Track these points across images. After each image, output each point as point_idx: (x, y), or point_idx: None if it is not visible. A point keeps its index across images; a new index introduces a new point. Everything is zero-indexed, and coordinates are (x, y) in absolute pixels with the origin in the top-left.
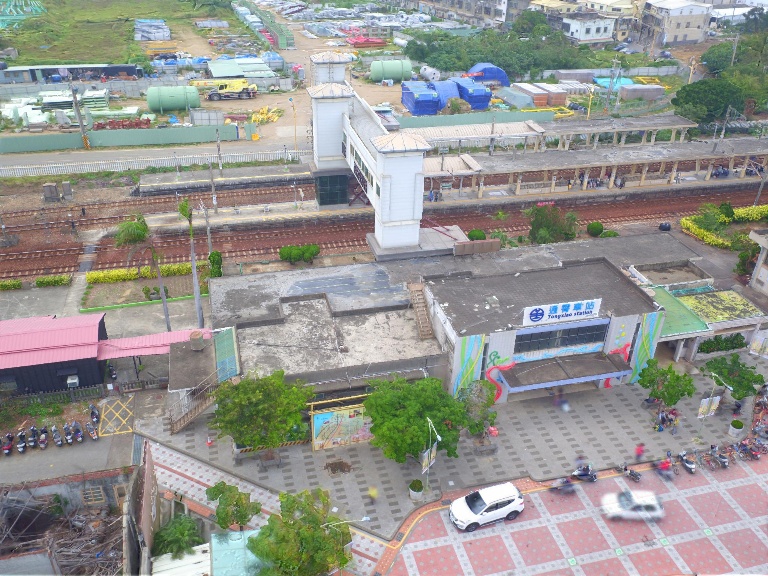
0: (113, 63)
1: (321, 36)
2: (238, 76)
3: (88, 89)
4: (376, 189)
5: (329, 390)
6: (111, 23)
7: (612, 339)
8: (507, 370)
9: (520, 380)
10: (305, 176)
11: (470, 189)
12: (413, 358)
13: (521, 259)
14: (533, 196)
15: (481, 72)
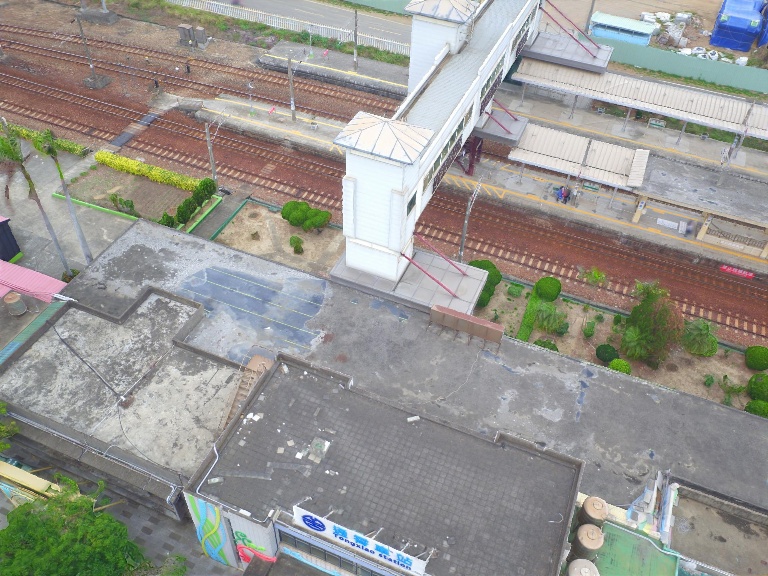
0: None
1: None
2: None
3: None
4: None
5: (56, 450)
6: None
7: None
8: (264, 561)
9: None
10: None
11: None
12: (164, 469)
13: (522, 372)
14: (722, 252)
15: None
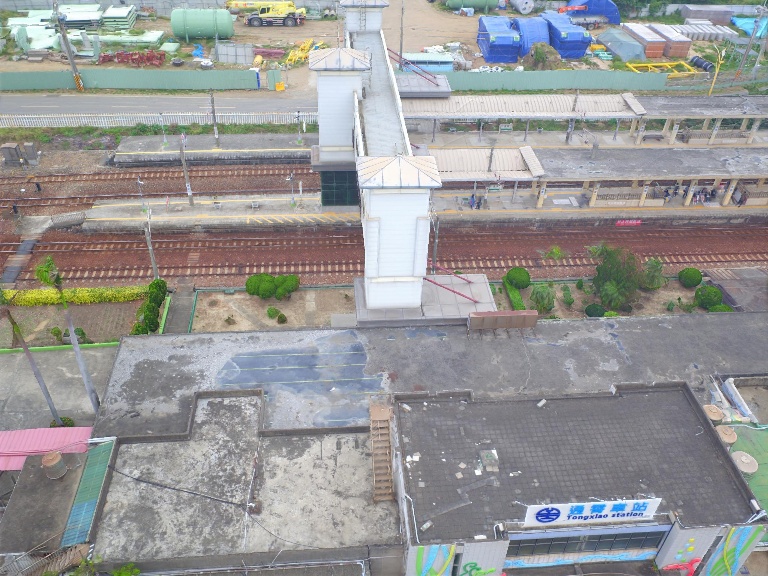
0: None
1: None
2: None
3: (115, 4)
4: None
5: None
6: None
7: (671, 553)
8: None
9: None
10: None
11: (529, 191)
12: (348, 547)
13: (565, 343)
14: (613, 211)
15: (584, 5)
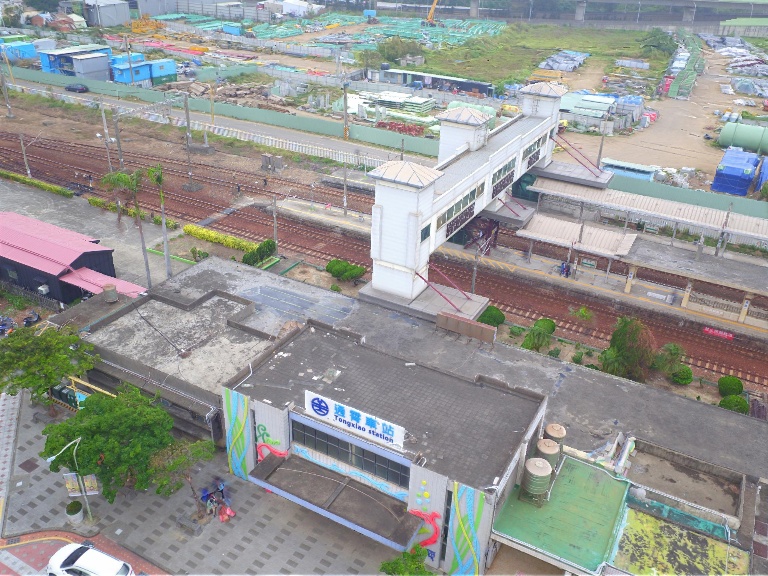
0: (488, 82)
1: (740, 93)
2: (564, 110)
3: (424, 96)
4: None
5: (126, 381)
6: (541, 51)
7: (412, 493)
8: (277, 457)
9: (274, 474)
10: None
11: None
12: (207, 391)
13: (510, 364)
14: (704, 316)
15: None
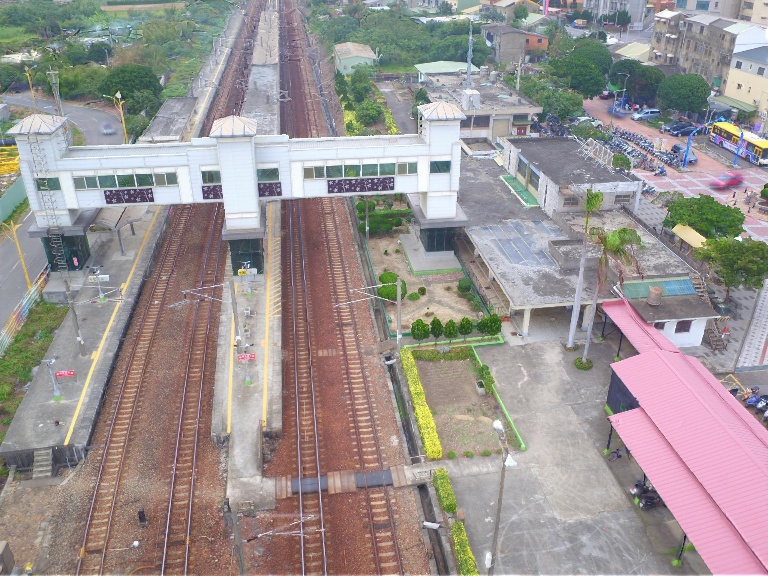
0: None
1: None
2: None
3: None
4: (430, 169)
5: None
6: None
7: None
8: None
9: None
10: (136, 288)
11: None
12: None
13: None
14: None
15: None
